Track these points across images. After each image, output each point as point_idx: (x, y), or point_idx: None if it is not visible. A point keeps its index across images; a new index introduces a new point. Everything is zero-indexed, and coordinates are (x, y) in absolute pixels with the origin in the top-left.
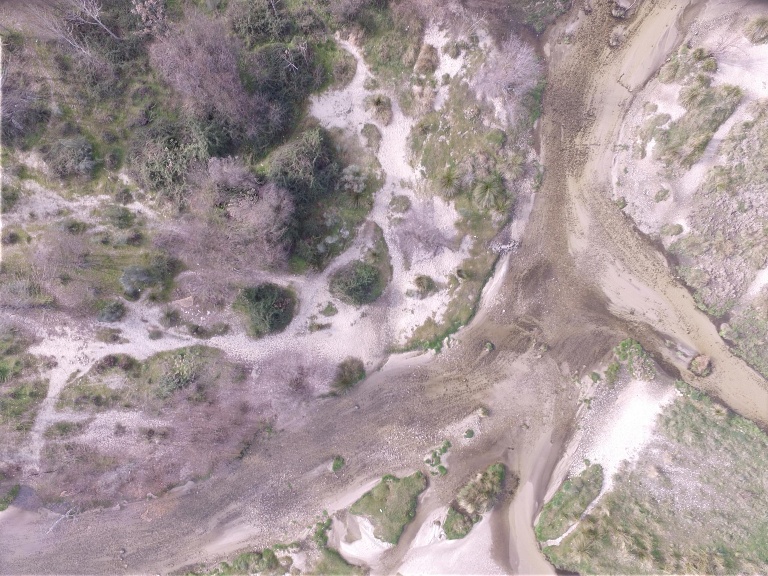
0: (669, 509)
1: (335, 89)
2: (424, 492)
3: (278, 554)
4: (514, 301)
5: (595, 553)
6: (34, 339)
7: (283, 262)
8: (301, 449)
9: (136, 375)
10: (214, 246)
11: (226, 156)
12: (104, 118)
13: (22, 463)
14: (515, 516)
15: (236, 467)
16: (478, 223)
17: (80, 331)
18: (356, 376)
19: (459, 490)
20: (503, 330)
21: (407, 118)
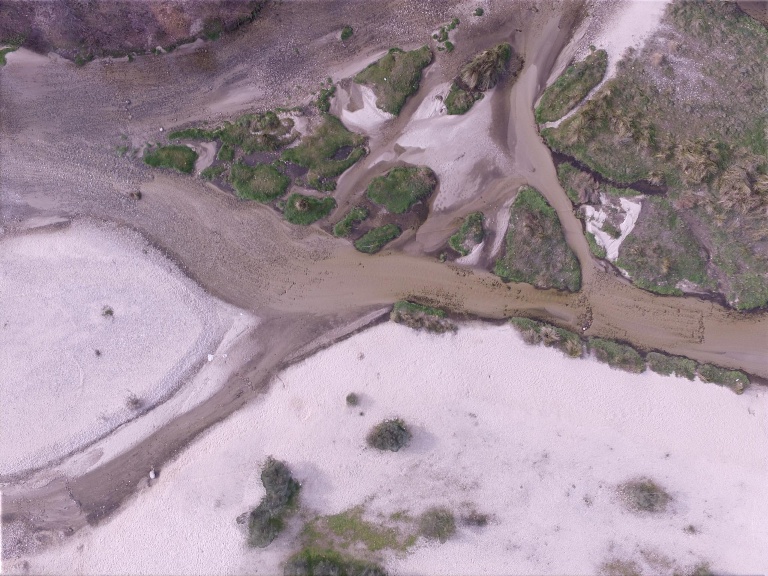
0: (669, 99)
1: None
2: (429, 67)
3: (280, 116)
4: None
5: (592, 136)
6: None
7: None
8: (311, 16)
9: None
10: None
11: None
12: None
13: (36, 3)
14: (517, 97)
15: (246, 30)
16: None
17: None
18: None
19: (464, 66)
20: None
21: None
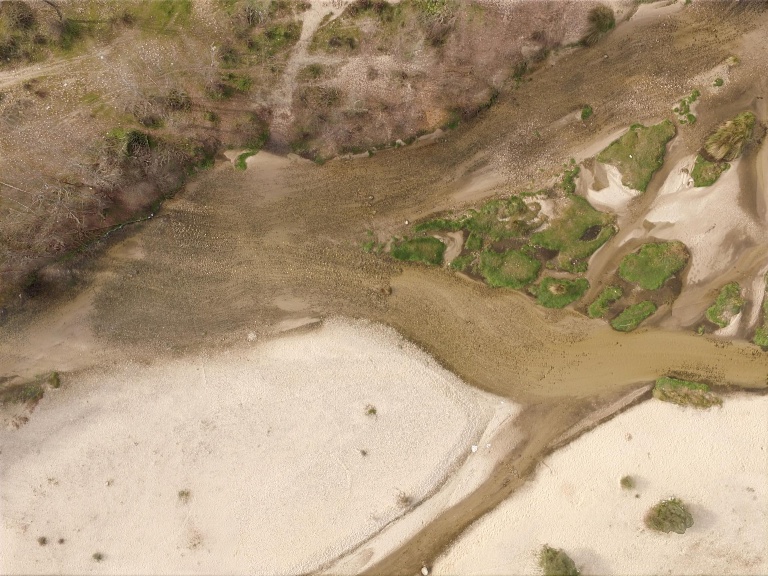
0: None
1: None
2: (672, 140)
3: (526, 200)
4: None
5: None
6: None
7: None
8: (549, 98)
9: (389, 18)
10: None
11: None
12: None
13: (274, 106)
14: (763, 165)
15: (484, 116)
16: None
17: None
18: (608, 22)
19: (708, 138)
20: None
21: None
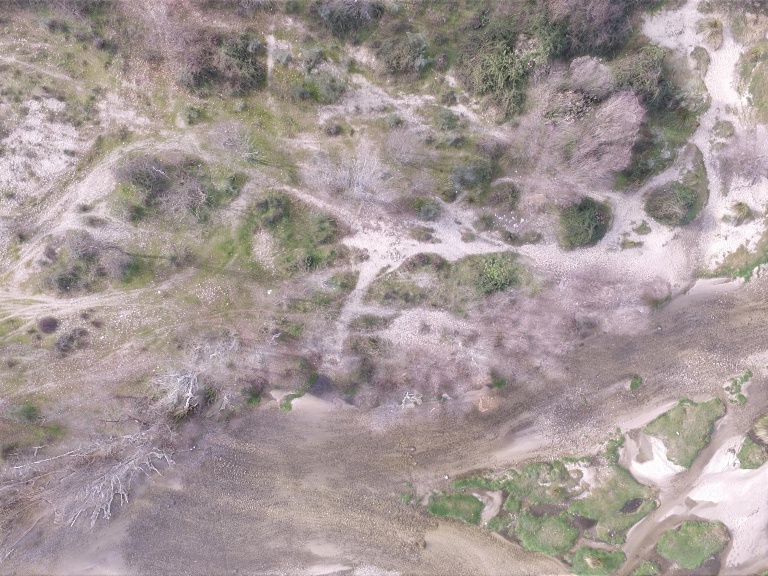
0: None
1: (668, 9)
2: (721, 419)
3: (569, 466)
4: None
5: None
6: (349, 230)
7: (609, 175)
8: (599, 365)
9: (446, 275)
10: (534, 155)
11: (557, 66)
12: (437, 19)
13: (324, 352)
14: None
15: (532, 377)
16: None
17: (394, 227)
18: (664, 297)
19: (757, 420)
20: None
21: (736, 45)
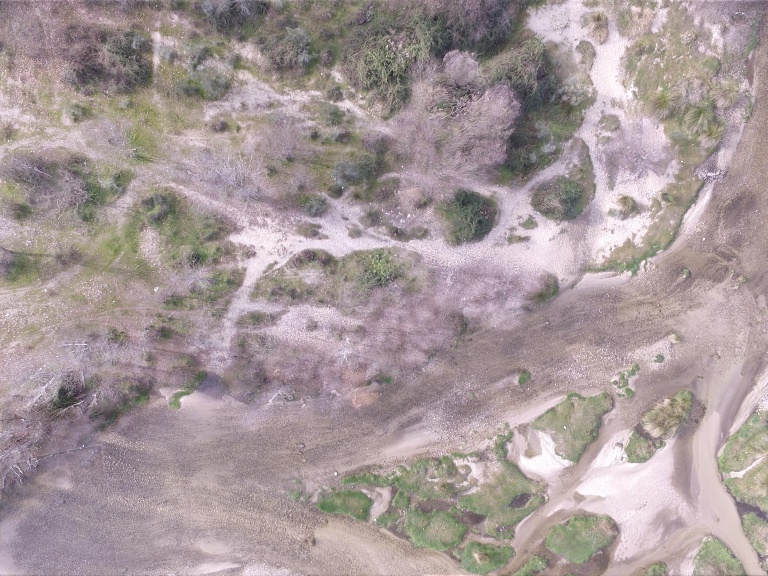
0: None
1: (553, 3)
2: (609, 413)
3: (457, 462)
4: (715, 230)
5: None
6: (235, 227)
7: (493, 169)
8: (488, 360)
9: (332, 271)
10: (420, 150)
11: (442, 61)
12: (322, 14)
13: (212, 349)
14: (699, 445)
15: (421, 372)
16: (686, 148)
17: (281, 223)
18: (551, 291)
19: (645, 414)
20: (701, 258)
21: (622, 38)
